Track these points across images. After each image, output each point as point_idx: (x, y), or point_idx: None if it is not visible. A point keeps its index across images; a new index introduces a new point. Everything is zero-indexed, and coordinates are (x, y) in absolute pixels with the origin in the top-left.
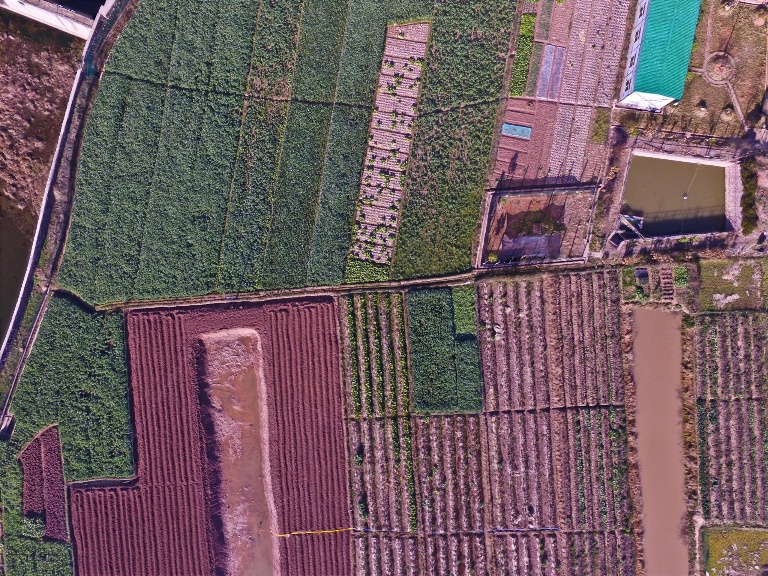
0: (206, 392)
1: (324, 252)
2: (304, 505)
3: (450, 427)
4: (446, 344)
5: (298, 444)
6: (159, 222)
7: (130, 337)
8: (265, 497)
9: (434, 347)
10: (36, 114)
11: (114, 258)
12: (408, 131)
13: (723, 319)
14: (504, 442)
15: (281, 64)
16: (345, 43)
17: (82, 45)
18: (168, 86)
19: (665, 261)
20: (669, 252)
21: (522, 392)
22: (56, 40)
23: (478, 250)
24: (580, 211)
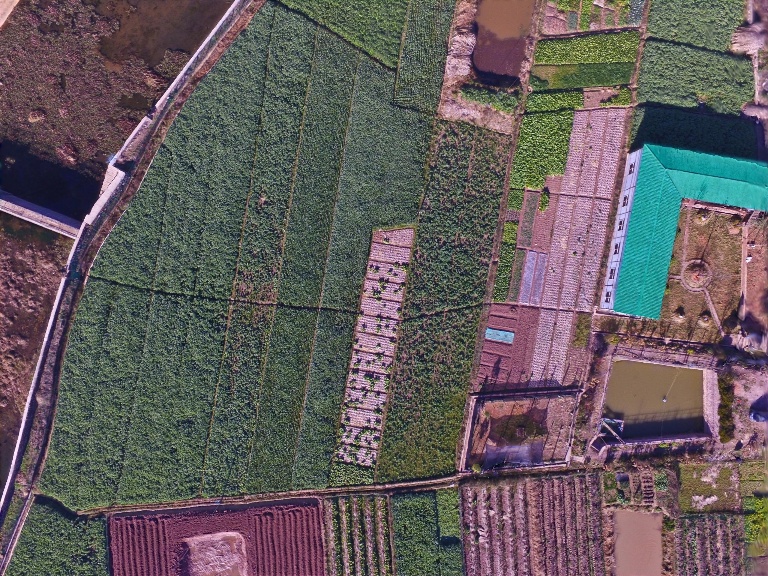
0: None
1: (309, 457)
2: None
3: None
4: (430, 549)
5: None
6: (143, 428)
7: (113, 542)
8: None
9: (418, 551)
10: (19, 311)
11: (97, 464)
12: (393, 335)
13: (702, 522)
14: None
15: (267, 269)
16: (330, 250)
17: (67, 243)
18: (153, 290)
19: (645, 469)
20: (649, 459)
21: None
22: (41, 237)
23: (462, 454)
24: (562, 415)
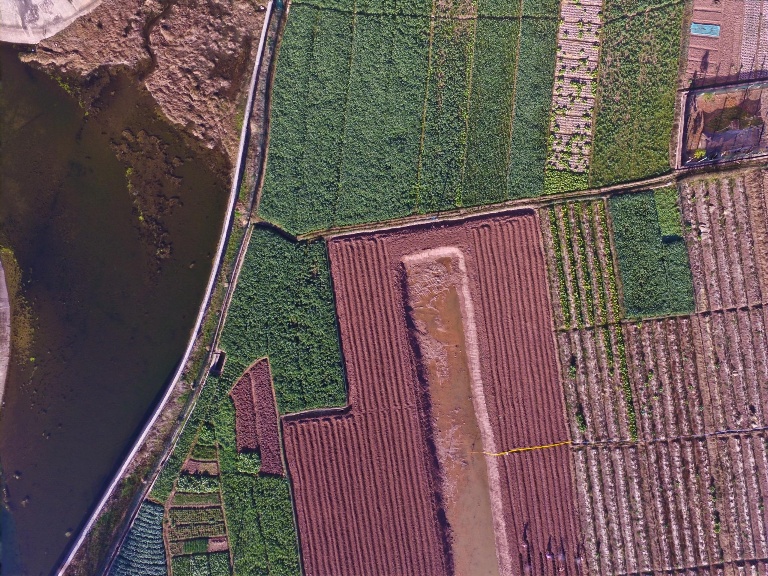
0: (410, 316)
1: (523, 164)
2: (520, 421)
3: (663, 331)
4: (654, 246)
5: (510, 359)
6: (357, 147)
7: (333, 265)
8: (476, 418)
9: (641, 251)
10: (220, 54)
11: (314, 186)
12: (596, 39)
13: None
14: (719, 342)
15: None
16: None
17: None
18: (355, 13)
19: None
20: None
21: (733, 290)
22: None
23: (677, 151)
24: None
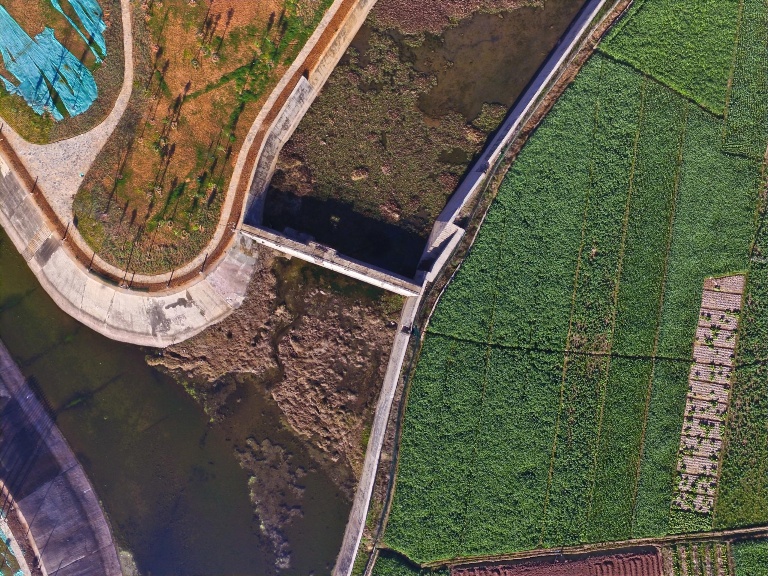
0: None
1: (649, 505)
2: None
3: None
4: None
5: None
6: (486, 481)
7: None
8: None
9: None
10: (348, 367)
11: (441, 517)
12: (726, 382)
13: None
14: None
15: (600, 320)
16: (665, 299)
17: (392, 298)
18: (489, 344)
19: None
20: None
21: None
22: (366, 293)
23: None
24: None
